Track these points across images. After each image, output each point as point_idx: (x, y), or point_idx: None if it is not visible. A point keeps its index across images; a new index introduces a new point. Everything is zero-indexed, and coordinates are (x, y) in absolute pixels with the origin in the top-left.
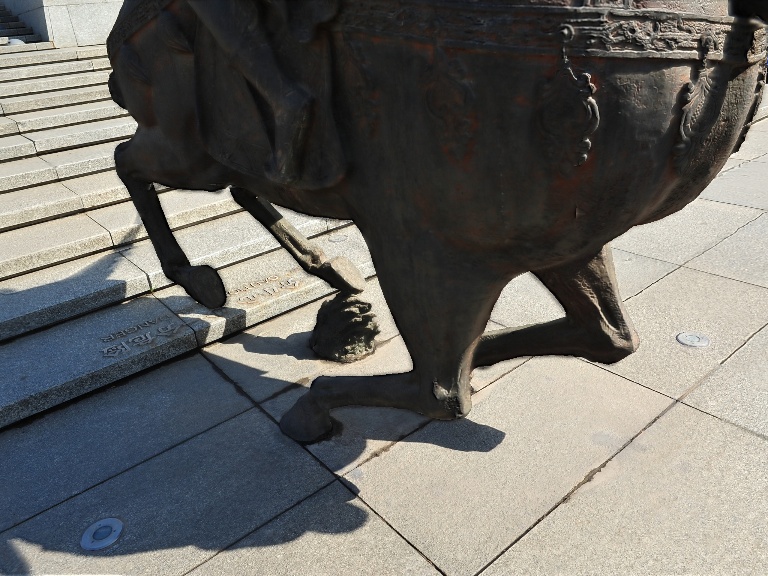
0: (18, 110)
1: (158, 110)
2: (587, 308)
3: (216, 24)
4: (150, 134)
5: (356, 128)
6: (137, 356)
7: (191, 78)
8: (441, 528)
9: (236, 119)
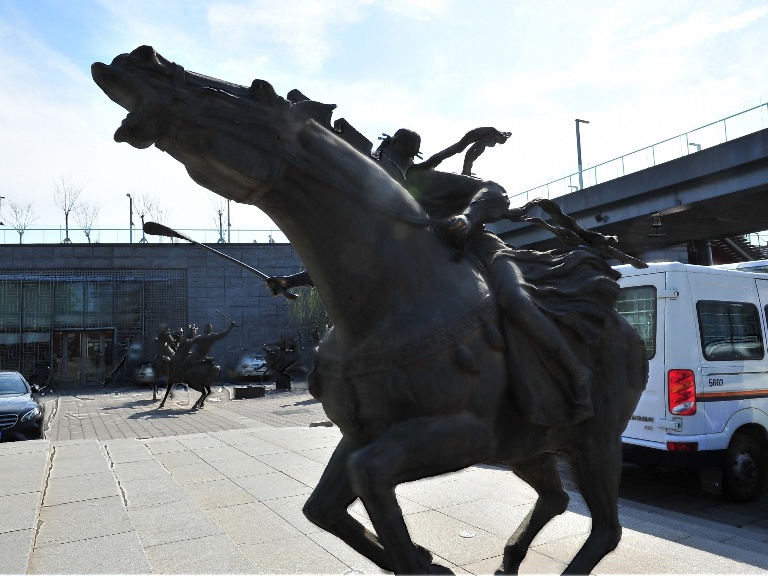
0: None
1: (482, 393)
2: (558, 482)
3: (553, 332)
4: (465, 417)
5: (603, 381)
6: None
7: (503, 367)
8: None
9: (537, 390)
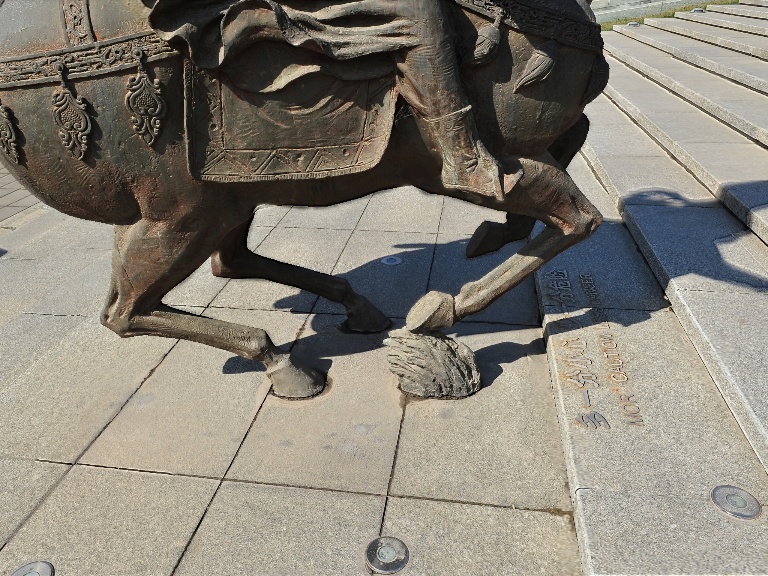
0: None
1: None
2: None
3: None
4: None
5: None
6: None
7: None
8: (232, 318)
9: None
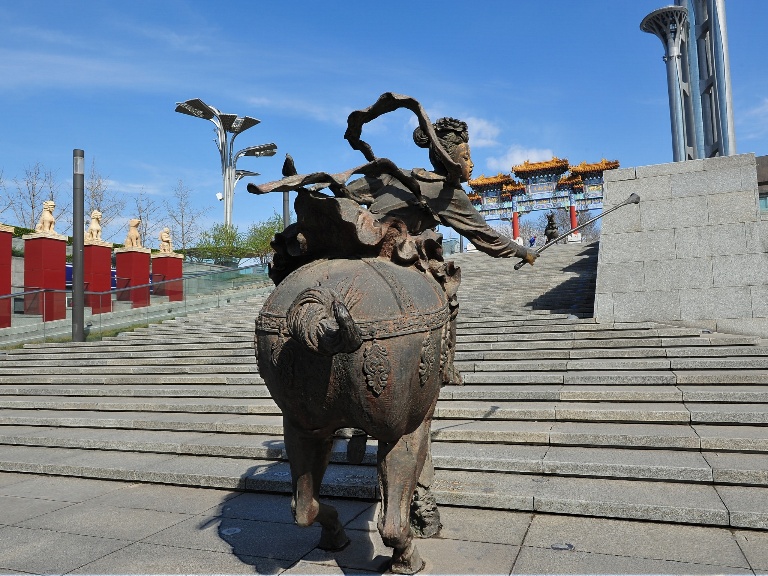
0: (492, 358)
1: None
2: None
3: None
4: None
5: None
6: (342, 486)
7: None
8: None
9: None
